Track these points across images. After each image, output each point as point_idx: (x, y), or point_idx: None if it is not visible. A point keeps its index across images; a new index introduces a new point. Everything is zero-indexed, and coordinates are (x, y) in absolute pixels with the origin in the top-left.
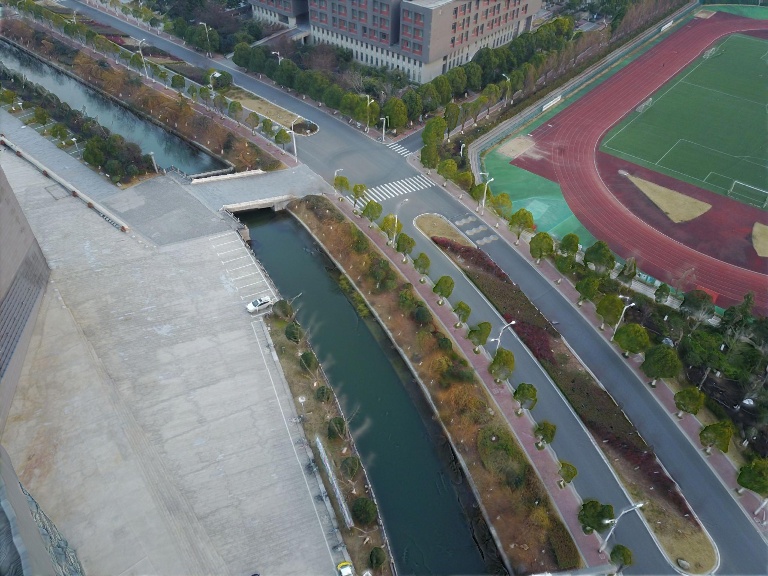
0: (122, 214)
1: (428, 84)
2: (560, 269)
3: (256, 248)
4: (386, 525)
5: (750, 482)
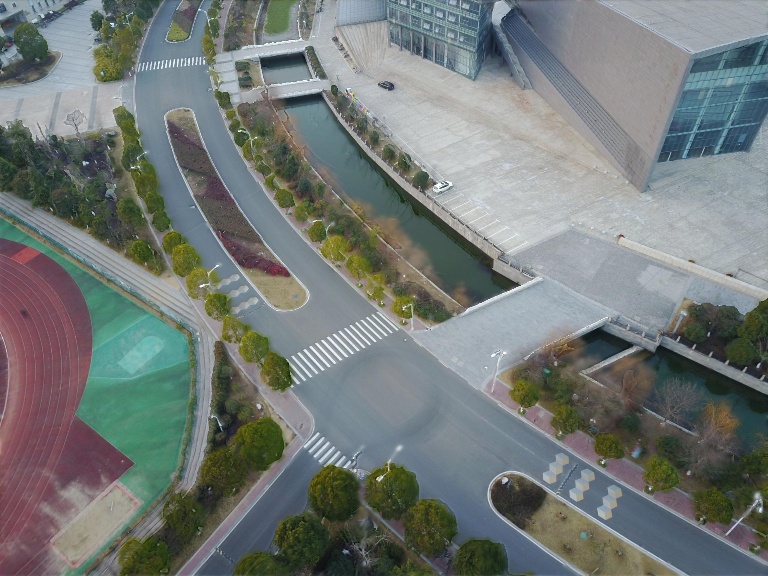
0: (647, 262)
1: (252, 565)
2: None
3: (482, 262)
4: (334, 136)
5: None
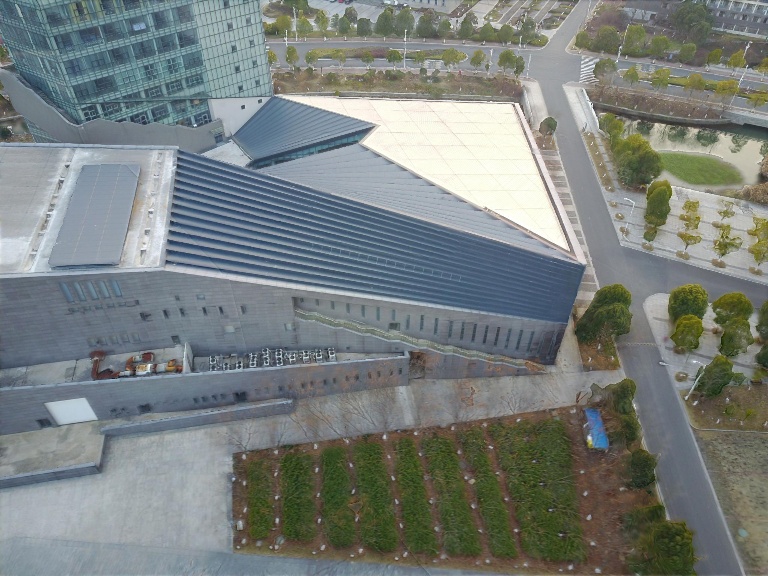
0: None
1: None
2: None
3: None
4: None
5: None
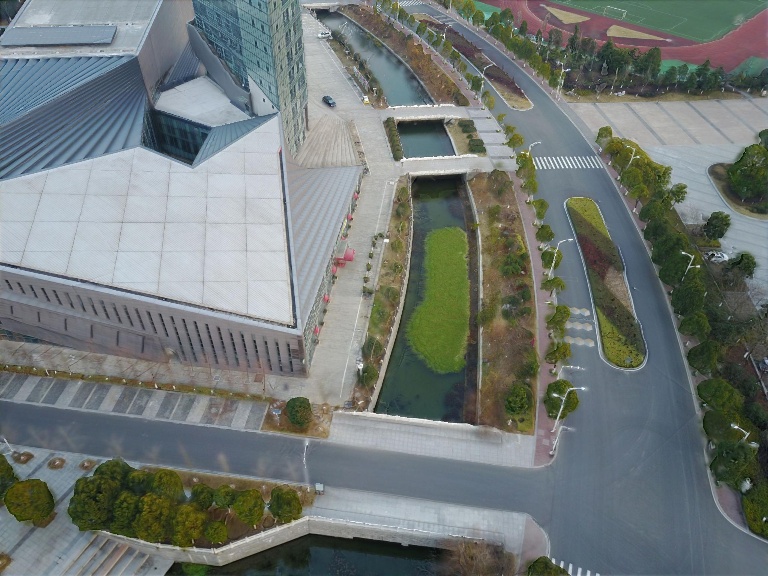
0: None
1: None
2: (486, 25)
3: None
4: None
5: (552, 81)
